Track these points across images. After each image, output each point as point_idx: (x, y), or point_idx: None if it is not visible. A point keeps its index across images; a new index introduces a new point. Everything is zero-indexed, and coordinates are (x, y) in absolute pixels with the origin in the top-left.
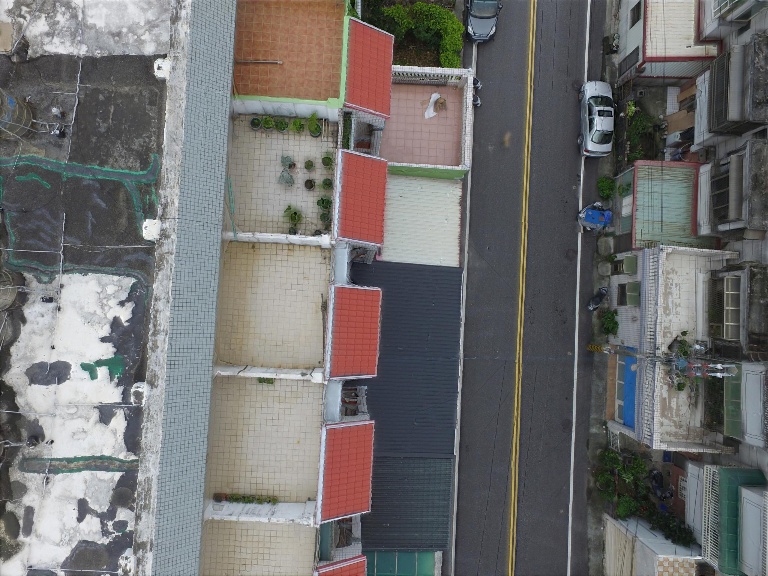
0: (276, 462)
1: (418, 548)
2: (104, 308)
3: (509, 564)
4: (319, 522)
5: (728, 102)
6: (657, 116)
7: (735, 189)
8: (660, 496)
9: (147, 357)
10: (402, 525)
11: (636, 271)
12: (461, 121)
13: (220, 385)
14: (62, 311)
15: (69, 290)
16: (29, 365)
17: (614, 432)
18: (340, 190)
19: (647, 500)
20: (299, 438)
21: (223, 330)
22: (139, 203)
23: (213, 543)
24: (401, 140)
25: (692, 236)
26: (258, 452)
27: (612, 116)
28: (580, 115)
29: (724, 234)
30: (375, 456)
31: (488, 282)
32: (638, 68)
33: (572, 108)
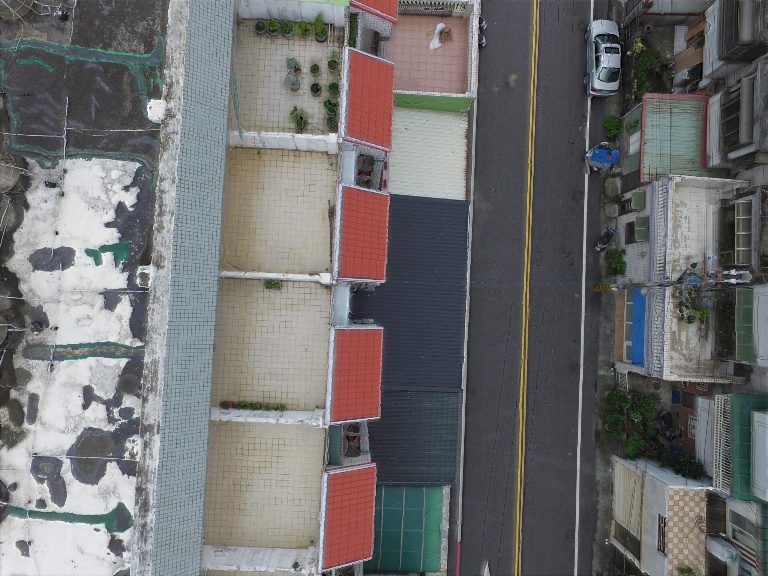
0: (283, 370)
1: (426, 482)
2: (108, 193)
3: (517, 507)
4: (328, 423)
5: (738, 25)
6: (664, 56)
7: (746, 112)
8: (669, 436)
9: None
10: (409, 459)
11: (644, 206)
12: (467, 52)
13: (226, 292)
14: (66, 197)
15: (73, 175)
16: (32, 251)
17: (622, 372)
18: (347, 89)
19: (656, 441)
20: (307, 346)
21: (229, 237)
22: (143, 86)
23: (220, 451)
24: (406, 71)
25: (701, 169)
26: (265, 360)
27: (619, 53)
28: (586, 55)
29: (734, 162)
30: (382, 389)
31: (494, 224)
32: (645, 3)
33: (578, 48)
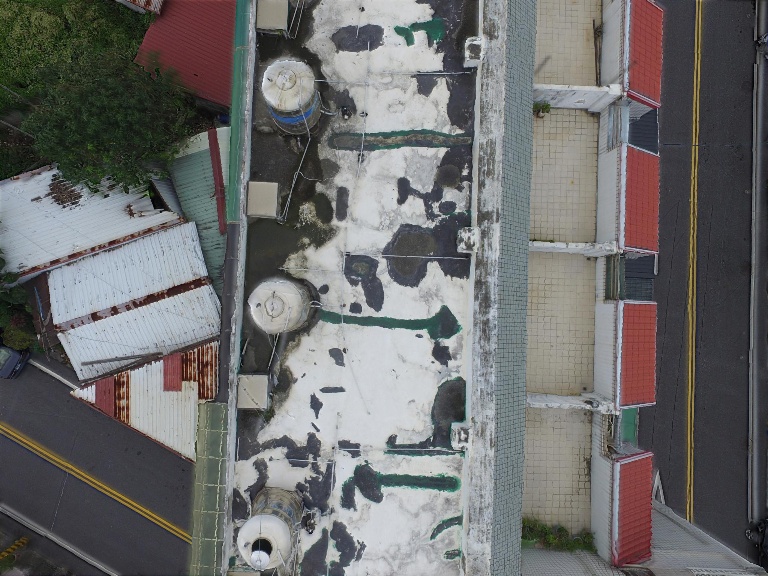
0: (549, 204)
1: None
2: None
3: (688, 412)
4: (623, 247)
5: None
6: None
7: None
8: None
9: (470, 19)
10: None
11: None
12: None
13: None
14: None
15: None
16: (335, 30)
17: None
18: None
19: None
20: (573, 178)
21: None
22: None
23: None
24: None
25: None
26: None
27: None
28: None
29: None
30: None
31: (659, 117)
32: None
33: None
